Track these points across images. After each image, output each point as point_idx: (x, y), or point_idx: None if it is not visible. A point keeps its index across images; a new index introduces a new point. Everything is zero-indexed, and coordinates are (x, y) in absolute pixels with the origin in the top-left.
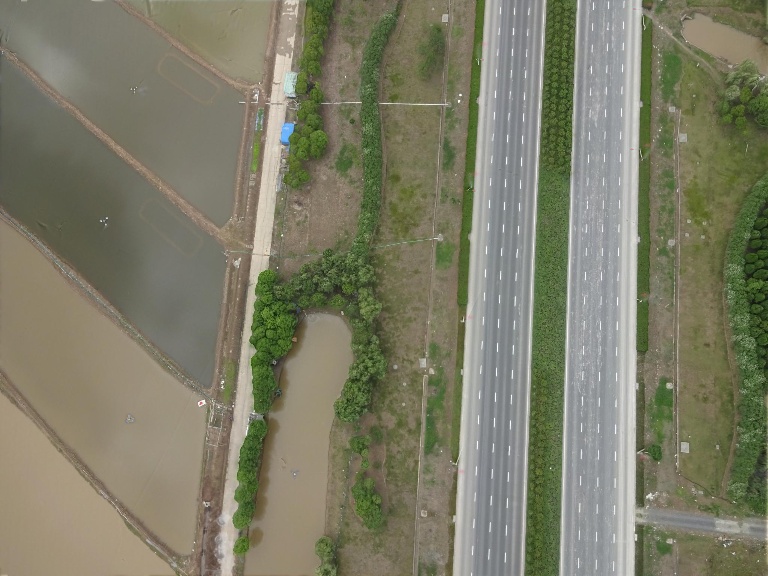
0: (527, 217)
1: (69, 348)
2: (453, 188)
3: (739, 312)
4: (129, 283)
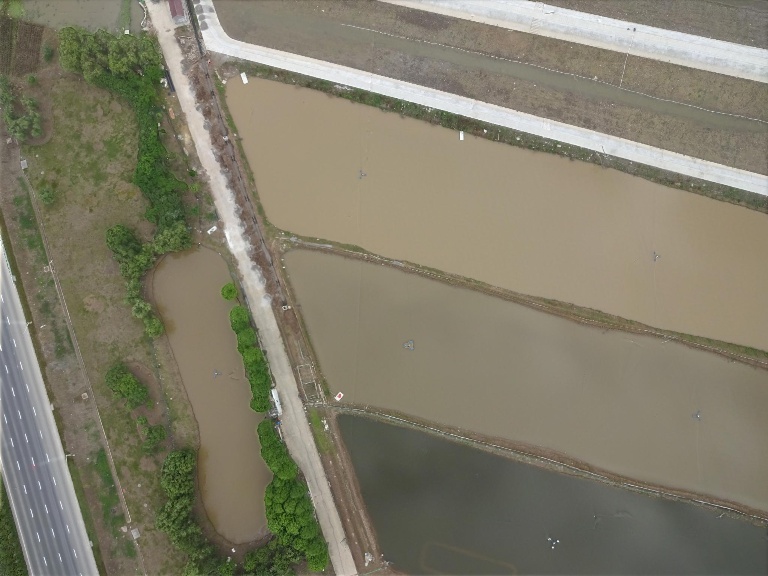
0: None
1: (519, 385)
2: None
3: None
4: (480, 488)
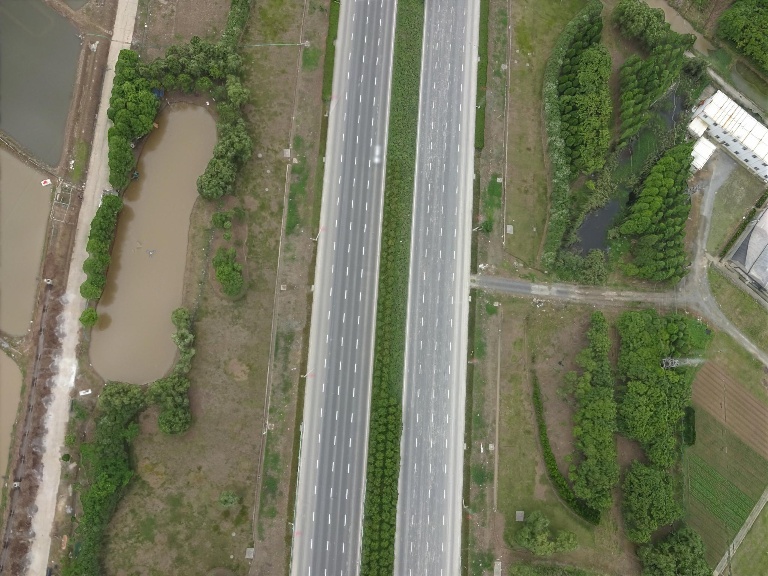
0: (387, 32)
1: None
2: (321, 2)
3: (553, 119)
4: None
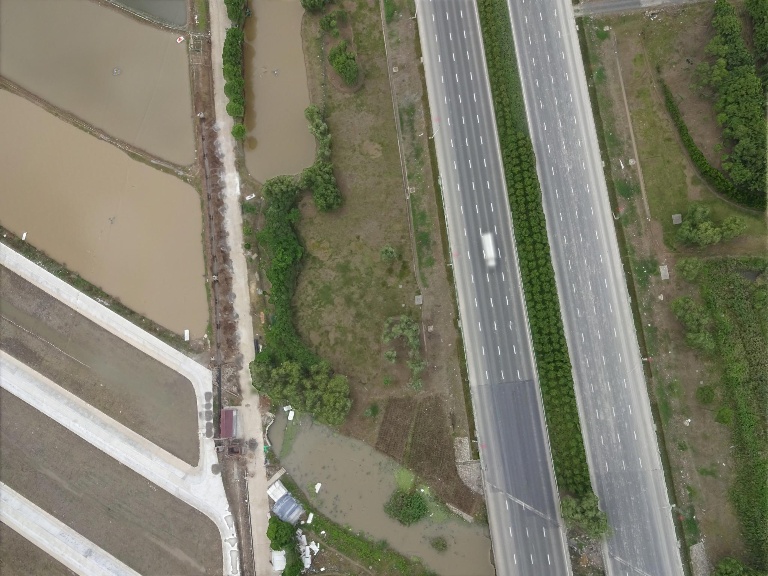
0: None
1: (48, 31)
2: None
3: None
4: None
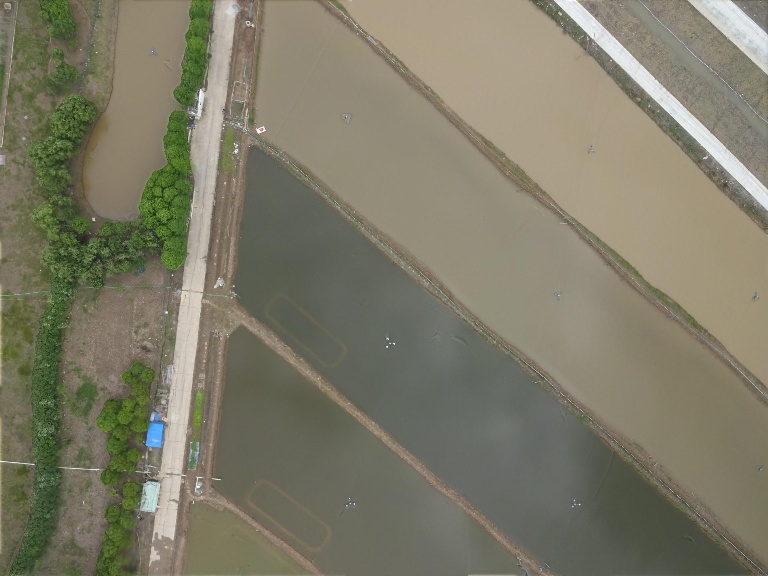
0: None
1: (425, 199)
2: None
3: None
4: (350, 266)
